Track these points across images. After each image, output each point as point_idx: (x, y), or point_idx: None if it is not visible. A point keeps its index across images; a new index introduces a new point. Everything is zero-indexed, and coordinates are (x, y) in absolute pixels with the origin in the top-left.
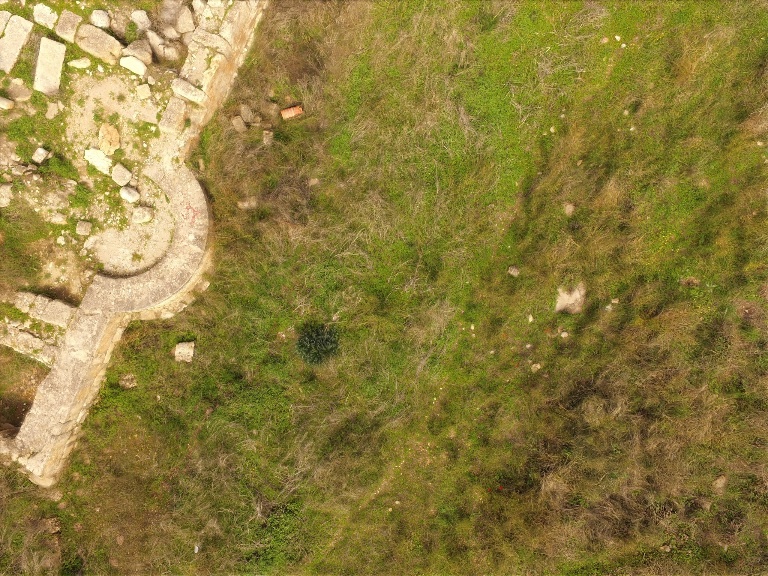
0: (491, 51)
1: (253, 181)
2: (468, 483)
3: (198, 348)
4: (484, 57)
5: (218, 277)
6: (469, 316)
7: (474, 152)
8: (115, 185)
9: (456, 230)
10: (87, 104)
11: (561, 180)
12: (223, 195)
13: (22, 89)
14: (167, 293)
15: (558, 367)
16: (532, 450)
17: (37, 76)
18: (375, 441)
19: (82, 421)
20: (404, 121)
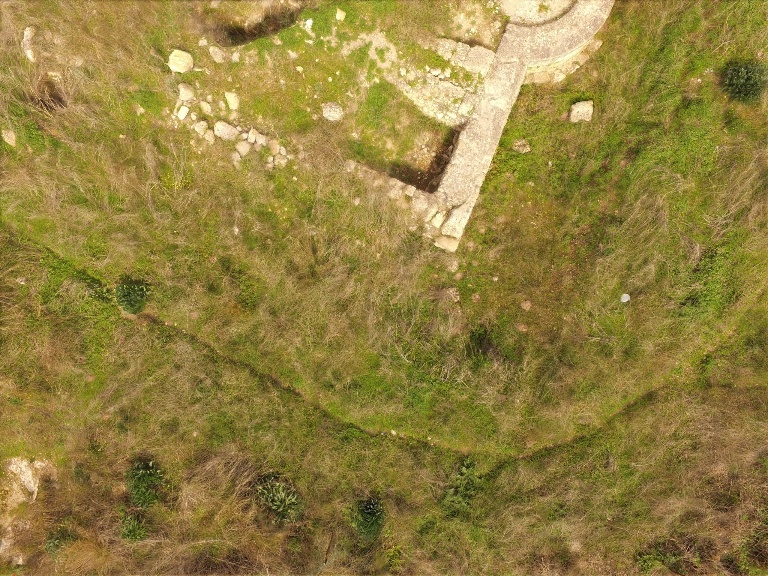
0: None
1: None
2: None
3: (595, 107)
4: None
5: (618, 31)
6: None
7: None
8: None
9: None
10: None
11: None
12: None
13: None
14: (582, 39)
15: None
16: None
17: None
18: None
19: None
20: None
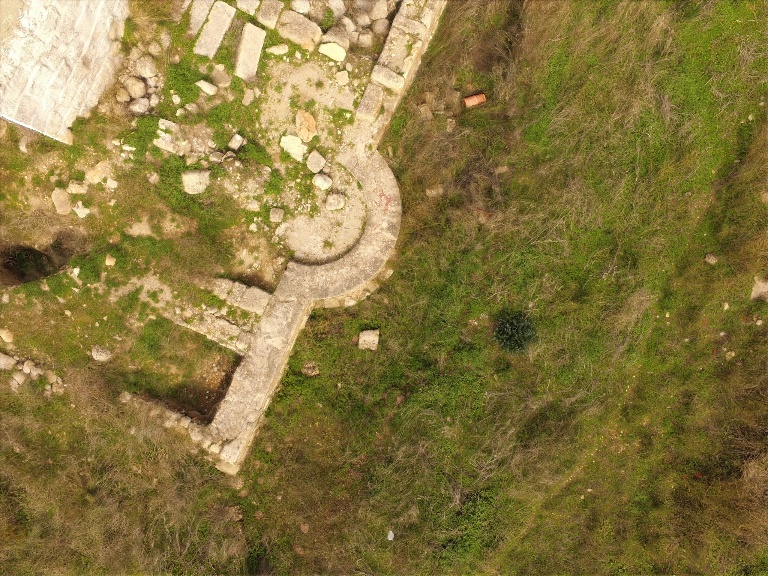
0: (690, 39)
1: (445, 168)
2: (661, 471)
3: (382, 336)
4: (684, 45)
5: (405, 265)
6: (665, 304)
7: (674, 140)
8: (305, 172)
9: (654, 218)
10: (284, 90)
11: (764, 168)
12: (414, 182)
13: (223, 75)
14: (361, 280)
15: (754, 355)
16: (727, 438)
17: (239, 62)
18: (571, 428)
19: (266, 409)
20: (602, 109)
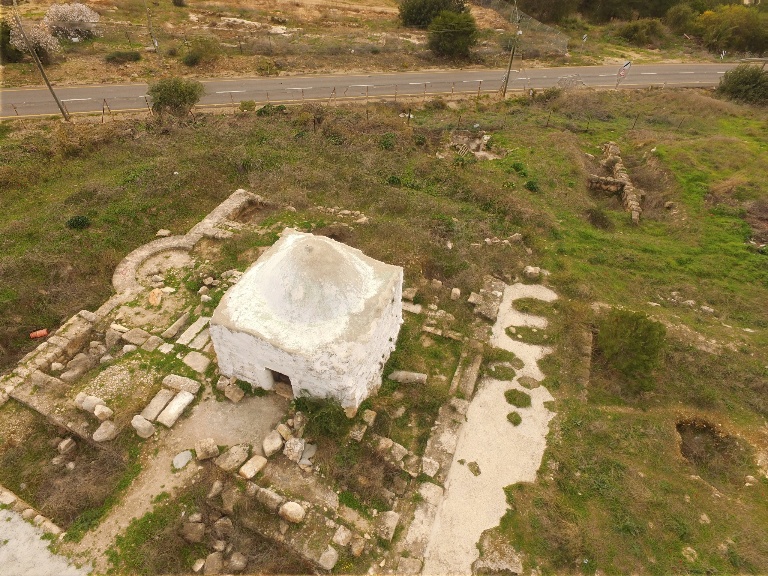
0: None
1: None
2: None
3: None
4: None
5: None
6: None
7: None
8: None
9: None
10: None
11: None
12: None
13: None
14: (153, 242)
15: None
16: None
17: None
18: None
19: None
20: None
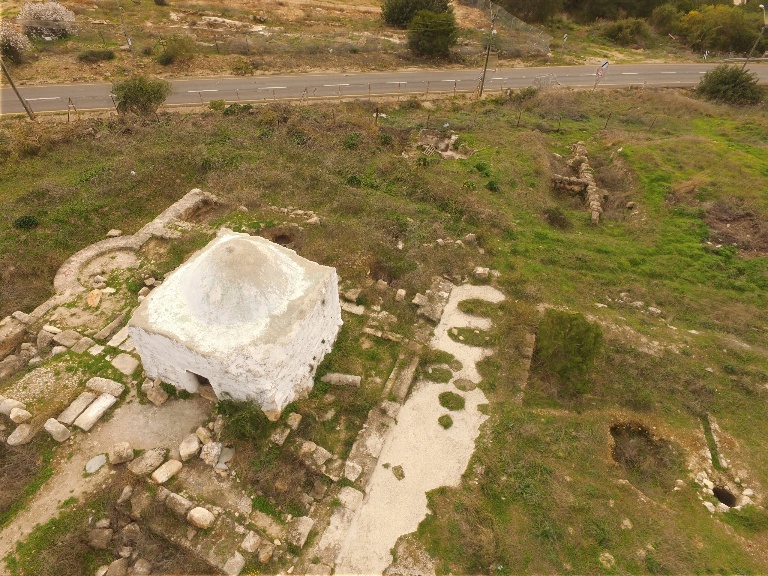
0: None
1: None
2: None
3: None
4: None
5: None
6: None
7: None
8: None
9: None
10: None
11: None
12: None
13: None
14: None
15: None
16: None
17: None
18: None
19: None
20: None
